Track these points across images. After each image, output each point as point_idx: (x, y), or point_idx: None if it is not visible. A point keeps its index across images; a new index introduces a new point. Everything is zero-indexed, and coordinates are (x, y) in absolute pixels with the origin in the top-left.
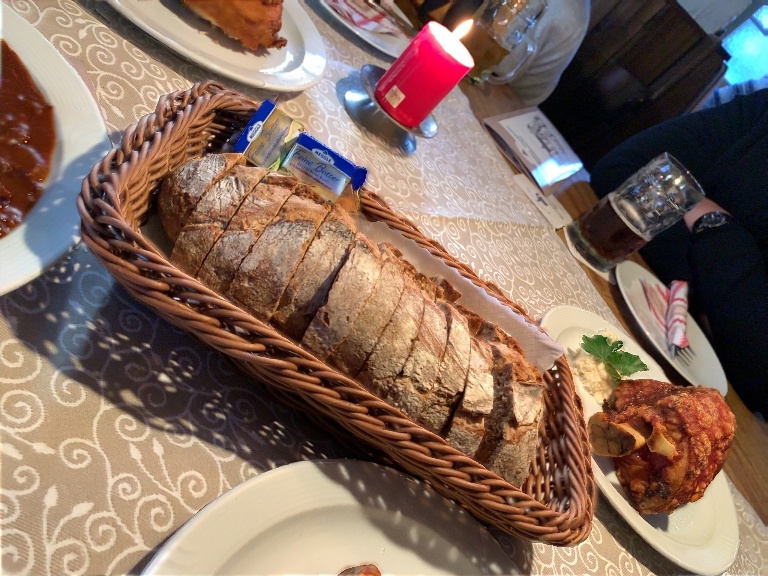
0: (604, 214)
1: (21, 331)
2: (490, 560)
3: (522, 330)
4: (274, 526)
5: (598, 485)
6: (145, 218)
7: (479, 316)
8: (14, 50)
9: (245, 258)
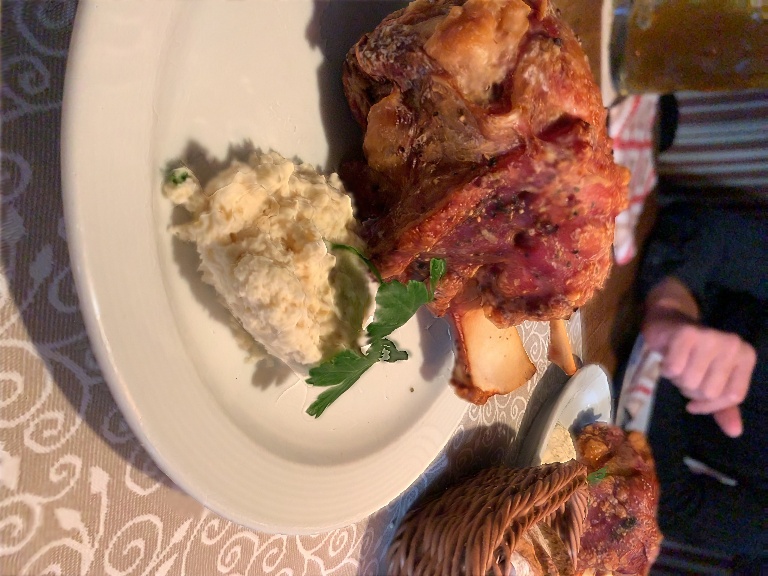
0: None
1: None
2: None
3: None
4: None
5: None
6: None
7: None
8: None
9: None
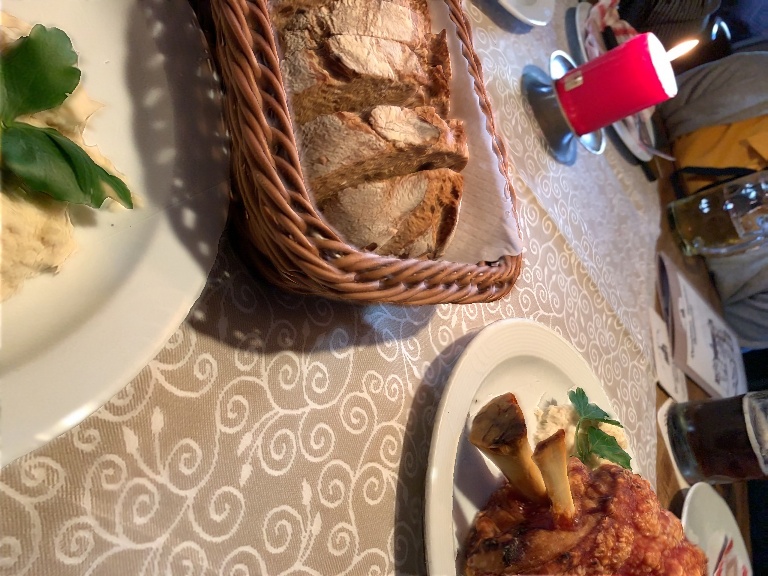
0: (727, 404)
1: None
2: (194, 206)
3: (493, 199)
4: None
5: (432, 442)
6: None
7: (448, 84)
8: None
9: None
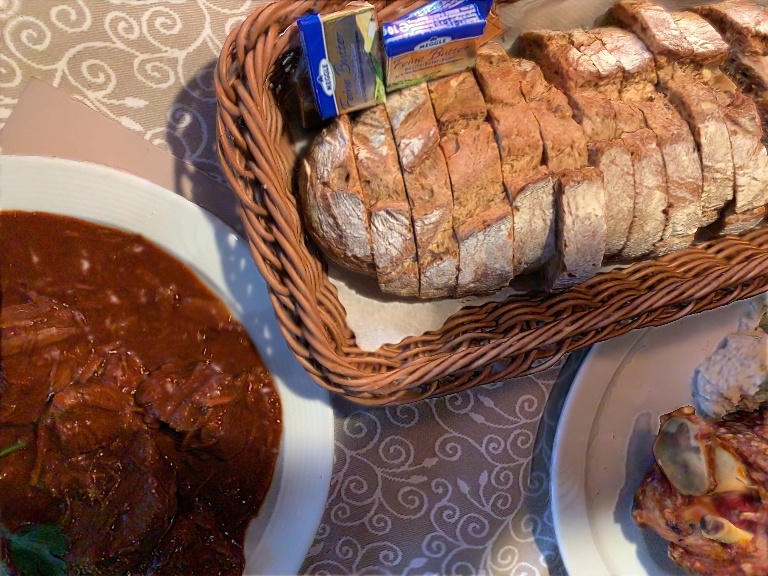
0: None
1: (343, 411)
2: None
3: None
4: (601, 399)
5: None
6: (323, 264)
7: (724, 51)
8: (36, 210)
9: (458, 277)
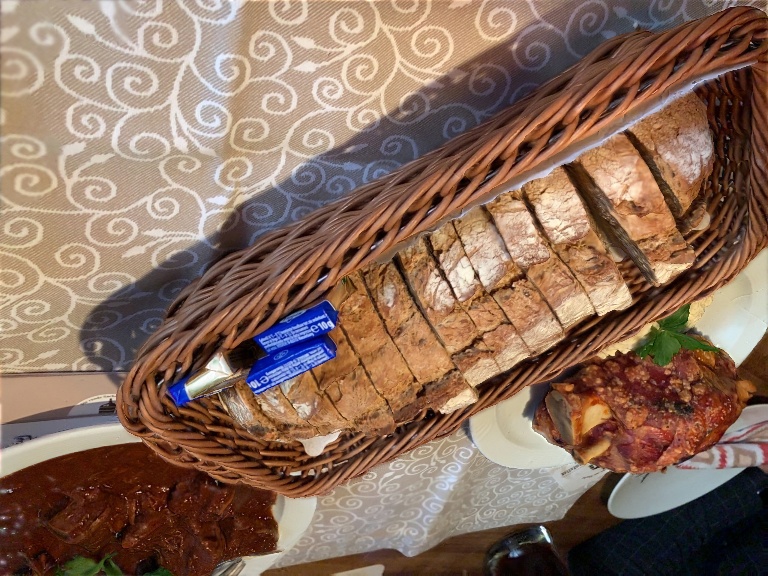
0: None
1: None
2: None
3: None
4: None
5: None
6: None
7: None
8: (33, 464)
9: None
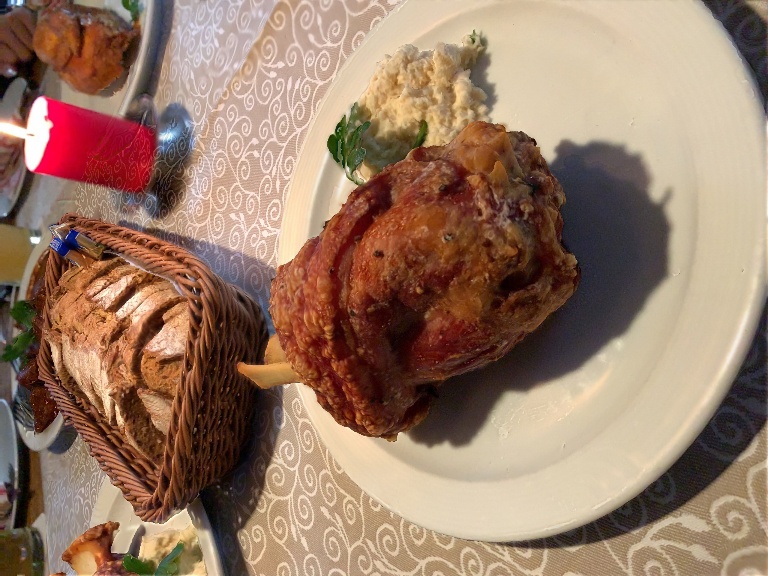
0: None
1: None
2: (190, 508)
3: None
4: None
5: None
6: None
7: (118, 320)
8: None
9: None
